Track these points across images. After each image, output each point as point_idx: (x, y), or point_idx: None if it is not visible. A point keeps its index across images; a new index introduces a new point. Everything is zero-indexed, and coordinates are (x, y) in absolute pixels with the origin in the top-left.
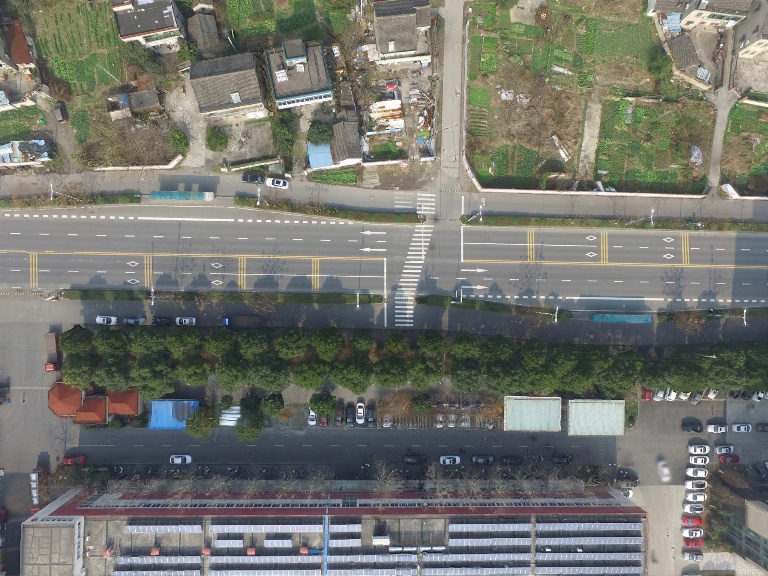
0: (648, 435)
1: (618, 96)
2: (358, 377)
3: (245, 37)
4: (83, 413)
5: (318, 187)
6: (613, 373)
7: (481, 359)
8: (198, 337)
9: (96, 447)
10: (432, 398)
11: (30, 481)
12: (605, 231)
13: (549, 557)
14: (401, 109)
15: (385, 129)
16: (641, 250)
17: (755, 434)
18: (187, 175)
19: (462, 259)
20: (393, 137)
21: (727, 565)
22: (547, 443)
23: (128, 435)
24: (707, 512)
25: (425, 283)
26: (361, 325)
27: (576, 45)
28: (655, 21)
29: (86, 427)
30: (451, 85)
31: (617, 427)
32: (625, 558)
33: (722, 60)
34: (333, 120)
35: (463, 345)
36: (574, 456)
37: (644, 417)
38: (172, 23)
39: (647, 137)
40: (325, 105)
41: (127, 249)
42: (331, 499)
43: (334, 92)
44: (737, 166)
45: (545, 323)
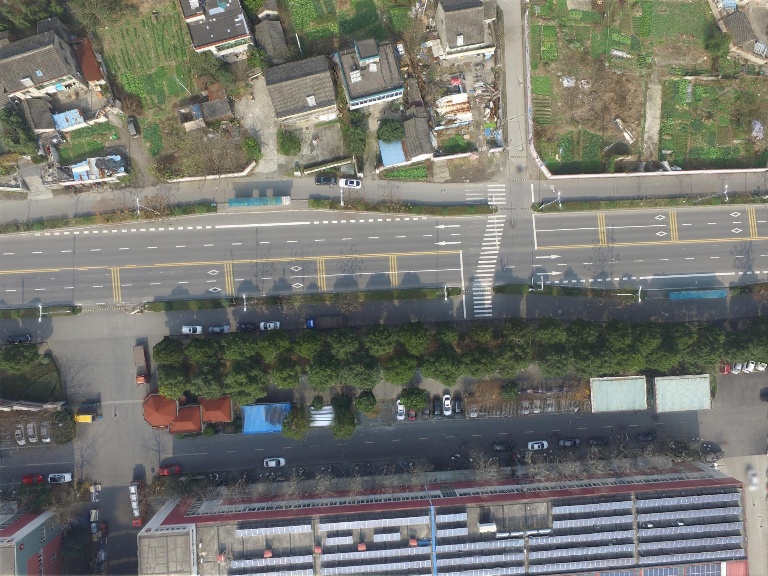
0: (728, 408)
1: (677, 76)
2: (450, 369)
3: (310, 40)
4: (179, 423)
5: (390, 185)
6: (698, 348)
7: (566, 343)
8: (288, 340)
9: (190, 456)
10: None
11: (129, 494)
12: (673, 210)
13: (651, 532)
14: (468, 102)
15: (454, 123)
16: (709, 226)
17: None
18: (260, 181)
19: (536, 246)
20: (460, 130)
21: None
22: (631, 422)
23: (220, 442)
24: None
25: (501, 273)
26: (441, 318)
27: (633, 28)
28: None
29: (180, 437)
30: (514, 75)
31: (703, 401)
32: (725, 528)
33: None
34: (402, 117)
35: (550, 330)
36: (658, 433)
37: (723, 390)
38: (244, 31)
39: (708, 114)
40: (394, 103)
41: (207, 258)
42: (429, 491)
43: None
44: None
45: (626, 304)
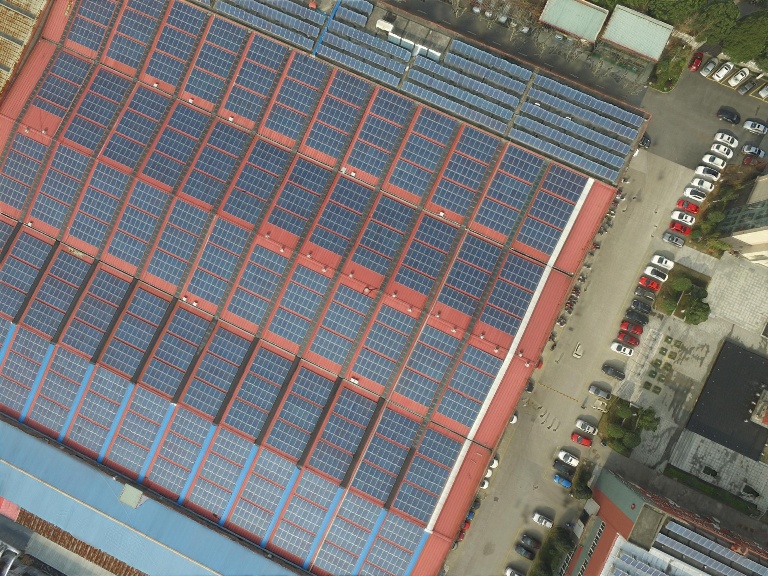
0: (679, 107)
1: None
2: None
3: None
4: None
5: None
6: None
7: None
8: None
9: None
10: None
11: None
12: None
13: (535, 111)
14: None
15: None
16: None
17: None
18: None
19: None
20: None
21: (705, 269)
22: (573, 71)
23: None
24: (707, 206)
25: None
26: None
27: None
28: None
29: None
30: None
31: (654, 50)
32: (610, 146)
33: None
34: None
35: None
36: None
37: (682, 88)
38: None
39: None
40: None
41: None
42: None
43: None
44: None
45: None
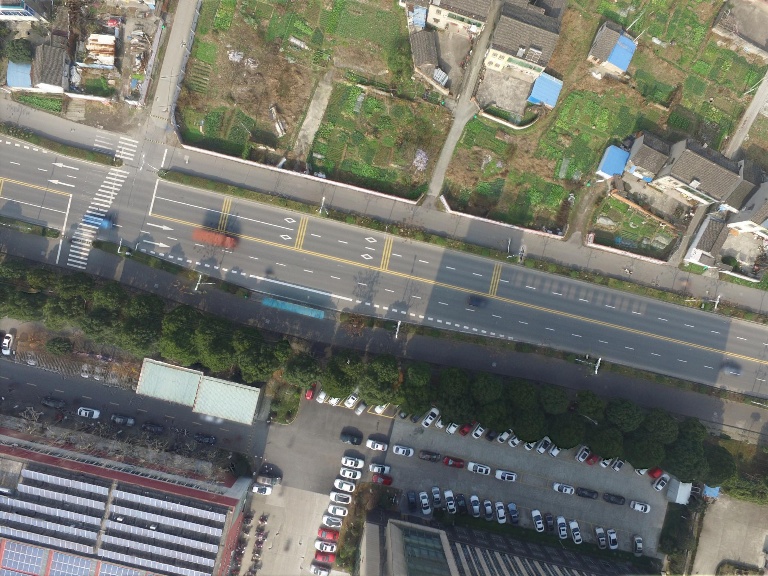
0: (303, 435)
1: (351, 81)
2: None
3: None
4: None
5: (21, 108)
6: (244, 356)
7: (122, 313)
8: None
9: None
10: (86, 346)
11: None
12: (306, 216)
13: (119, 527)
14: (114, 46)
15: (93, 63)
16: (339, 244)
17: (417, 461)
18: None
19: (150, 212)
20: (107, 74)
21: None
22: (195, 419)
23: None
24: (346, 529)
25: (107, 228)
26: (32, 256)
27: (319, 21)
28: (406, 13)
29: None
30: (179, 34)
31: (246, 415)
32: (199, 547)
33: (469, 67)
34: None
35: (98, 293)
36: (220, 439)
37: (303, 416)
38: None
39: (372, 130)
40: (36, 25)
41: None
42: None
43: (54, 16)
44: (461, 180)
45: None
